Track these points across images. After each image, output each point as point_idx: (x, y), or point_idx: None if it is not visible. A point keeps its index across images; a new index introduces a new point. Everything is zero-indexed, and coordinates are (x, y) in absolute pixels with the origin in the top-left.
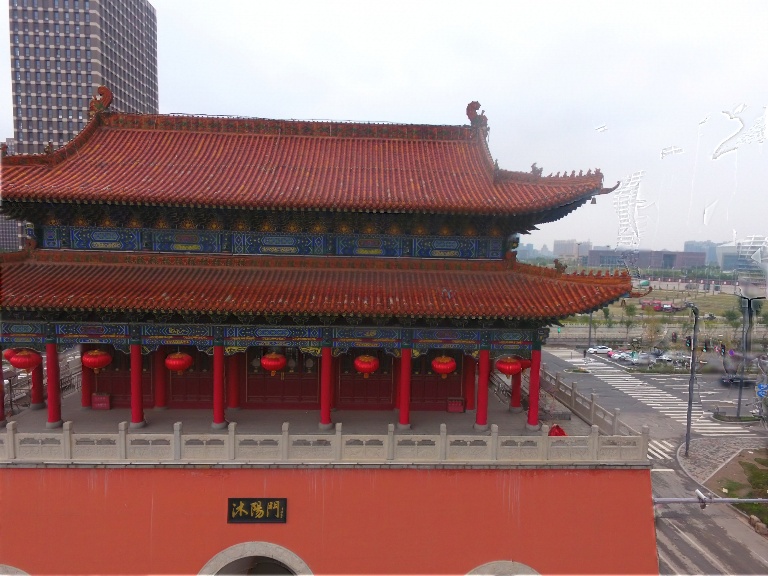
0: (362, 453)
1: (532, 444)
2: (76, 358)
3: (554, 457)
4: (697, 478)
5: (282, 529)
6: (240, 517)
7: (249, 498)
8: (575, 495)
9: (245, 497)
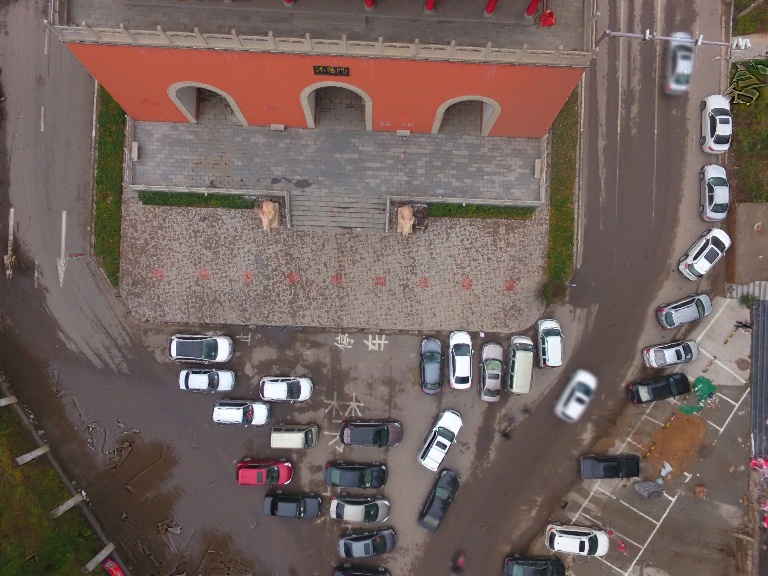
0: (396, 51)
1: (521, 31)
2: None
3: (525, 59)
4: None
5: (347, 78)
6: (321, 72)
7: (325, 66)
8: (530, 75)
9: (323, 66)
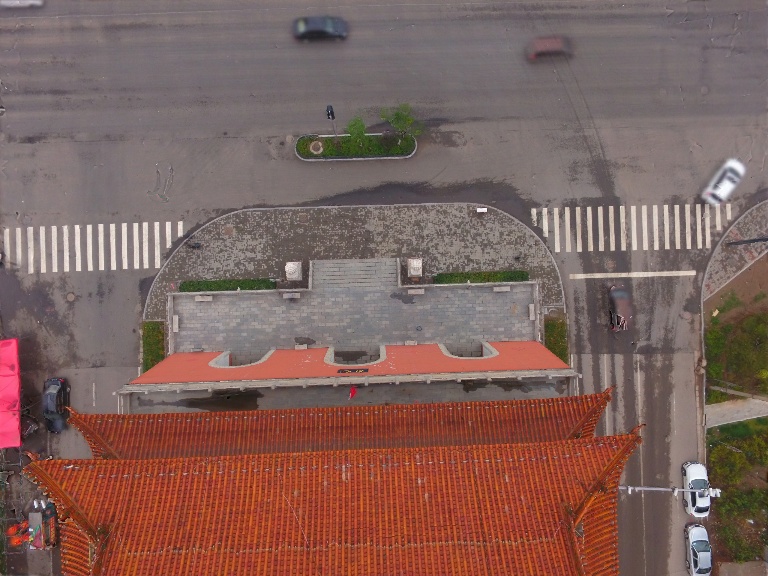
0: None
1: None
2: (122, 404)
3: None
4: (706, 292)
5: None
6: None
7: None
8: None
9: None
